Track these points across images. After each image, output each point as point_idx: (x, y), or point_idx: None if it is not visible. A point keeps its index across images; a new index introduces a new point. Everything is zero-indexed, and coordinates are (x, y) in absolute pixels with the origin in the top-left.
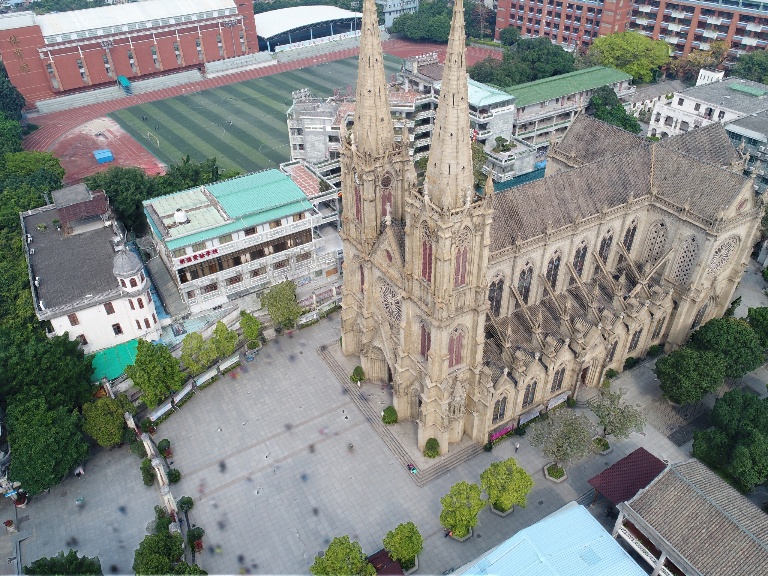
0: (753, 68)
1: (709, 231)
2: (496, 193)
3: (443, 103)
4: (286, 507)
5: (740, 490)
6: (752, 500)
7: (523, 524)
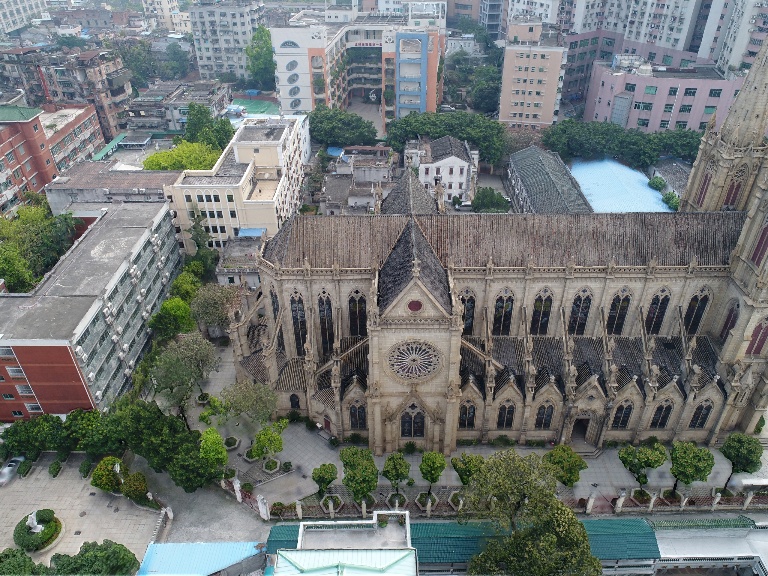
0: None
1: None
2: None
3: None
4: None
5: None
6: None
7: None
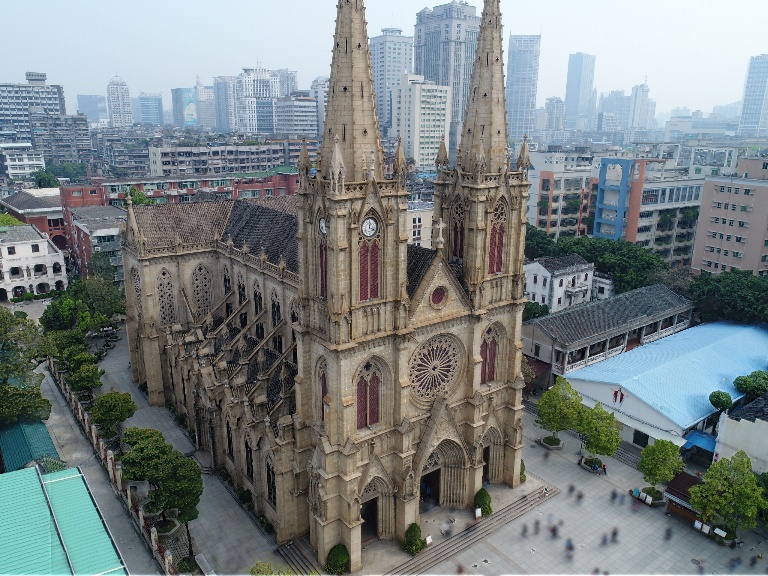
0: None
1: None
2: None
3: (497, 66)
4: None
5: None
6: None
7: (563, 434)
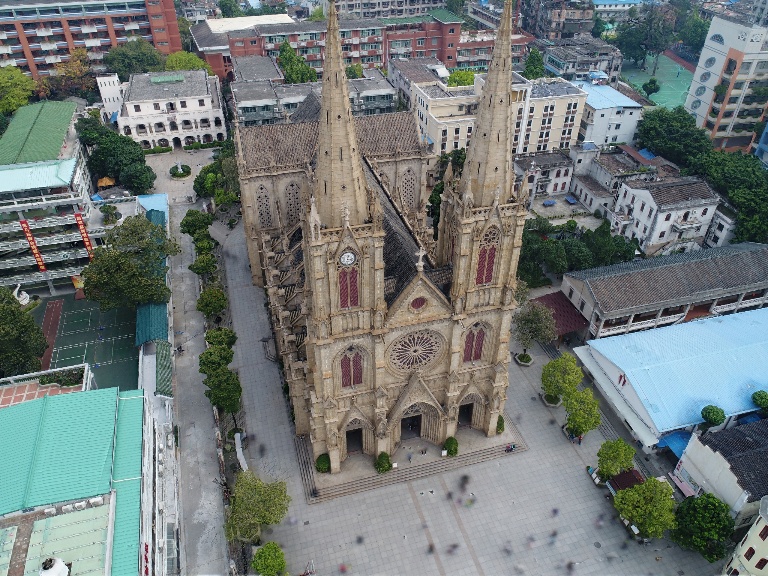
0: (133, 63)
1: (423, 157)
2: None
3: (500, 108)
4: (544, 571)
5: (550, 282)
6: (555, 282)
7: None
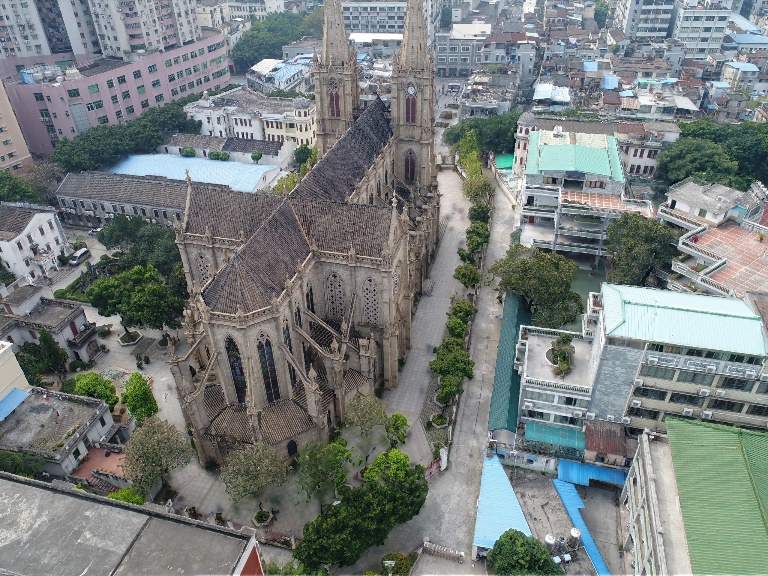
0: None
1: None
2: (354, 123)
3: None
4: None
5: None
6: None
7: None
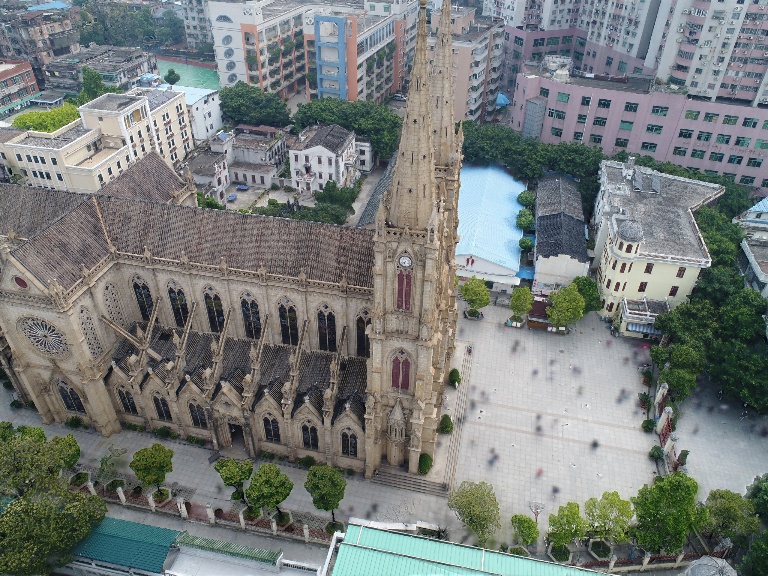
0: None
1: None
2: None
3: None
4: (570, 385)
5: None
6: None
7: None
